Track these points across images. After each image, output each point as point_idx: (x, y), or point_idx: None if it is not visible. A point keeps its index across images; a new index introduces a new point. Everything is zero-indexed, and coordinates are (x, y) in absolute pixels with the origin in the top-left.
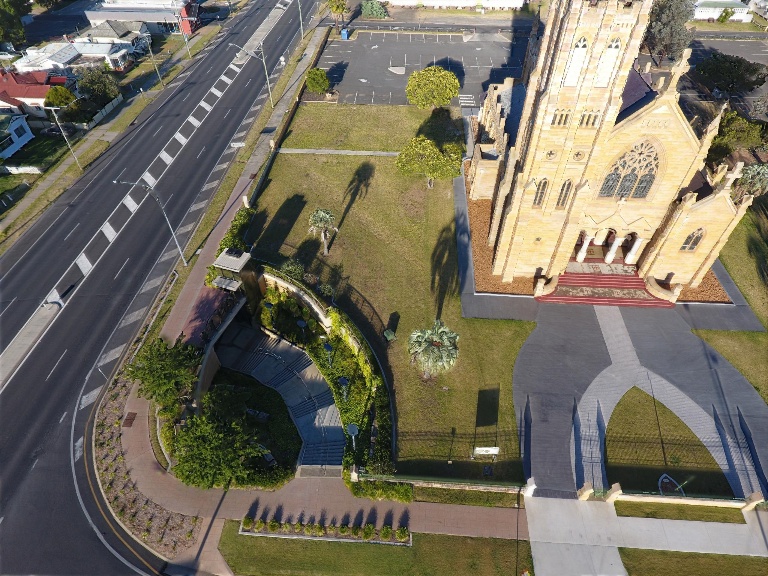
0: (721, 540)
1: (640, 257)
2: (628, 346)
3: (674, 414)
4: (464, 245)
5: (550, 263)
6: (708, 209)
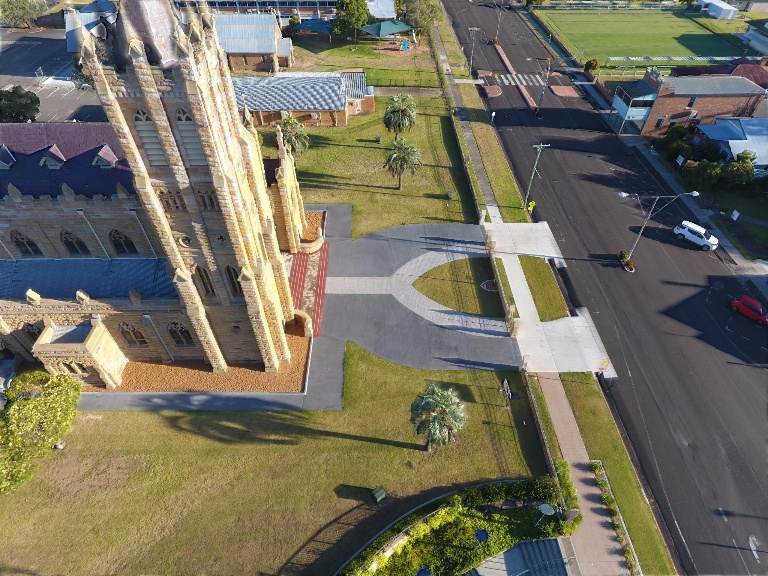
0: (516, 271)
1: (279, 244)
2: (371, 280)
3: (432, 269)
4: (216, 401)
5: (284, 309)
6: (287, 171)
